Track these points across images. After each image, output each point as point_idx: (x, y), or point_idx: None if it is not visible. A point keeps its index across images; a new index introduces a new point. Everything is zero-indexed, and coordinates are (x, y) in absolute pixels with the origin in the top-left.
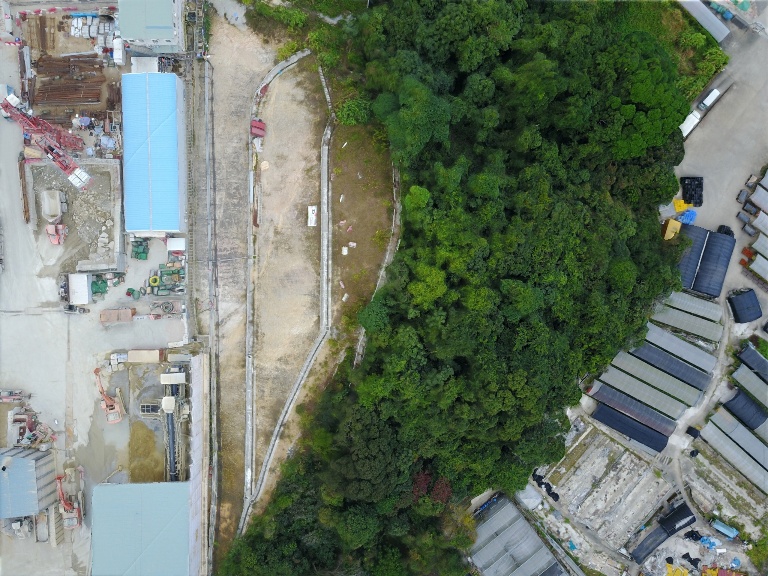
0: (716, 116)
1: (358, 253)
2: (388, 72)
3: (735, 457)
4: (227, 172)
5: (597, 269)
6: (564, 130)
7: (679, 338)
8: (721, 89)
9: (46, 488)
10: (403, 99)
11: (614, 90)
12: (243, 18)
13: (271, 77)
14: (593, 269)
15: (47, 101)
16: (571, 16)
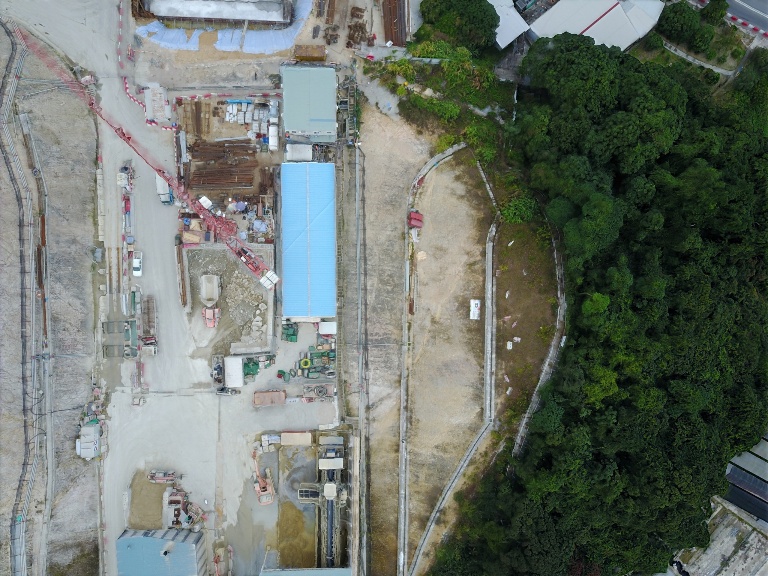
0: None
1: (522, 348)
2: (558, 176)
3: None
4: (380, 259)
5: (748, 364)
6: (716, 229)
7: None
8: None
9: (201, 570)
10: (587, 210)
11: None
12: (396, 108)
13: (427, 169)
14: (744, 364)
15: (202, 185)
16: (729, 123)
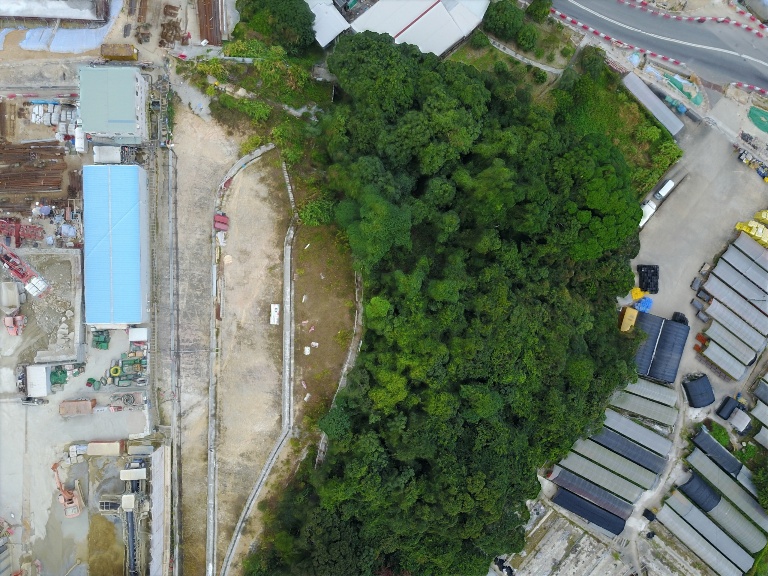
0: (671, 205)
1: (320, 353)
2: (350, 177)
3: (689, 539)
4: (190, 263)
5: (555, 367)
6: None
7: (636, 423)
8: (676, 179)
9: None
10: (364, 212)
11: (571, 195)
12: (208, 109)
13: (235, 170)
14: (551, 367)
15: (6, 189)
16: (530, 122)
